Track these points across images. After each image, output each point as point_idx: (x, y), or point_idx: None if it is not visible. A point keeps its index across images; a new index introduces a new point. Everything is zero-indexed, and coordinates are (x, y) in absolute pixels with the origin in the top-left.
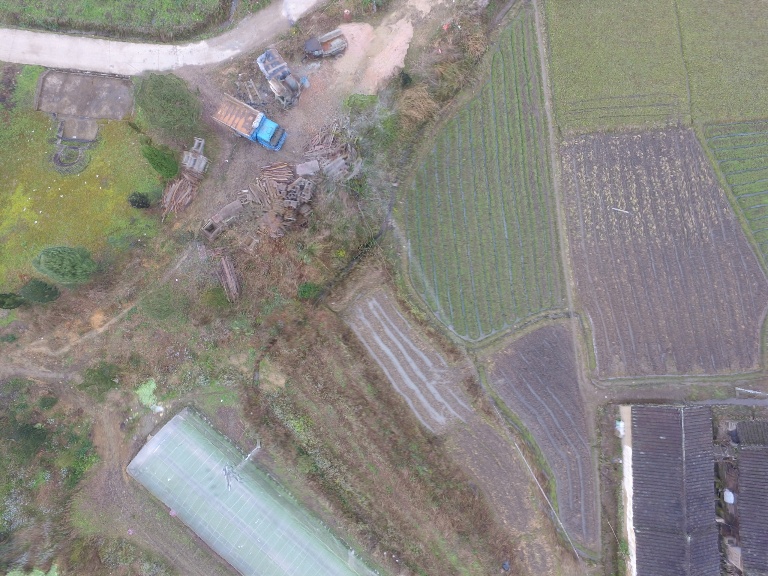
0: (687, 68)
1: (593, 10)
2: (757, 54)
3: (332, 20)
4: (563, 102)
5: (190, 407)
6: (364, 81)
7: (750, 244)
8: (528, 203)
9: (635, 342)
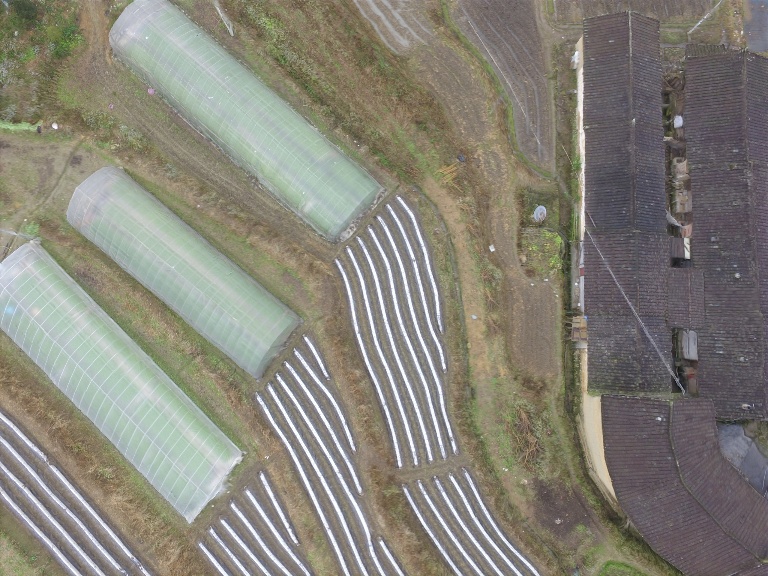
0: None
1: None
2: None
3: None
4: None
5: None
6: None
7: None
8: None
9: None
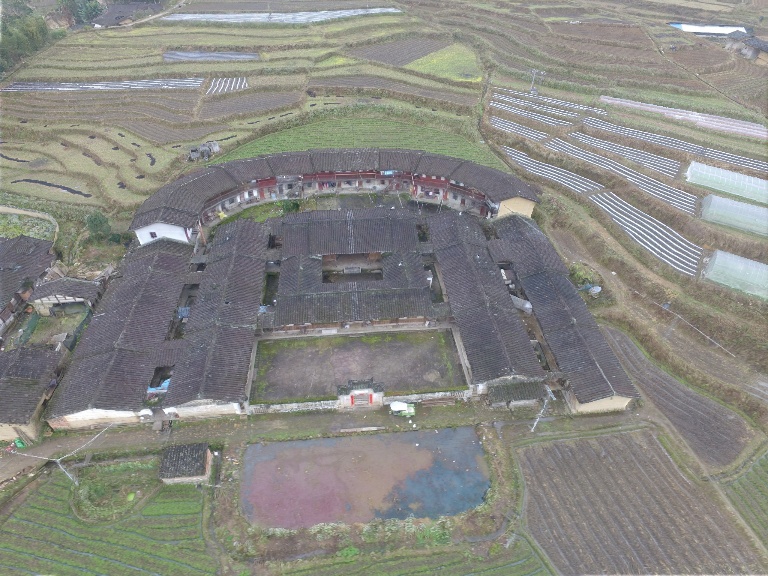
0: None
1: None
2: None
3: None
4: None
5: None
6: None
7: None
8: None
9: (635, 461)
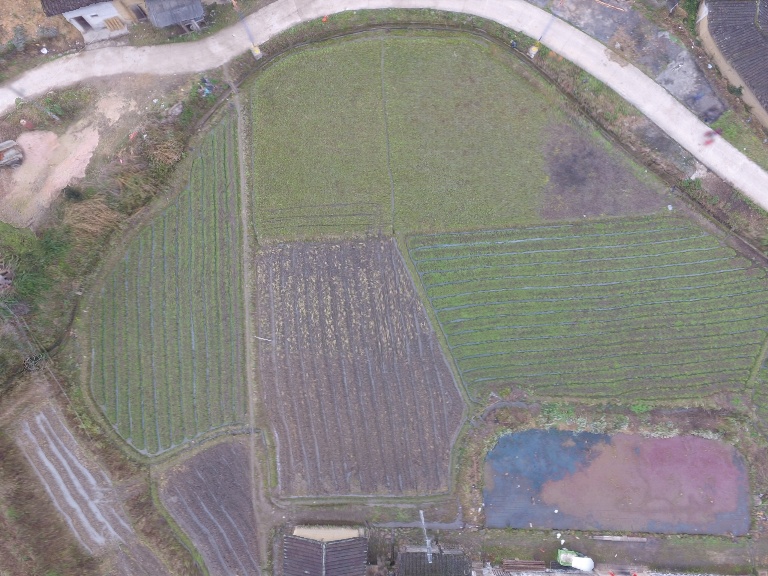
0: (393, 177)
1: (299, 116)
2: (466, 163)
3: (13, 128)
4: (261, 210)
5: None
6: (43, 190)
7: (447, 360)
8: (217, 314)
9: (320, 460)
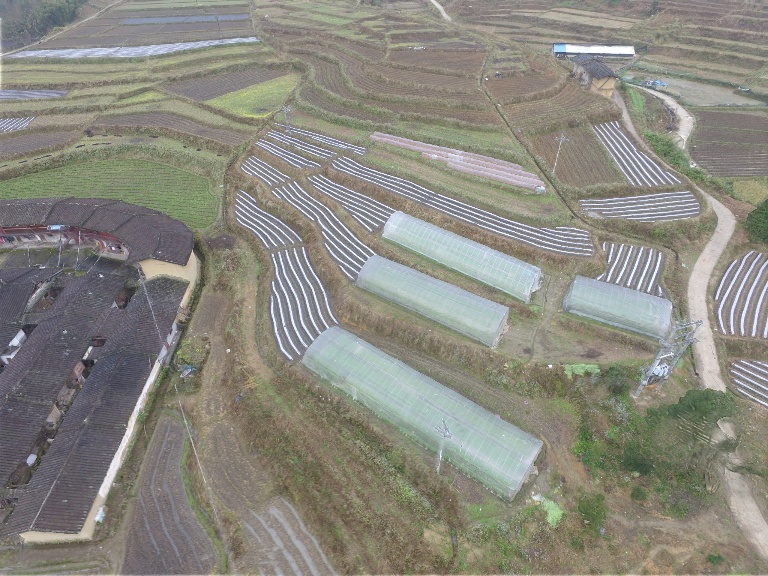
0: None
1: None
2: None
3: None
4: None
5: (509, 502)
6: None
7: None
8: None
9: None
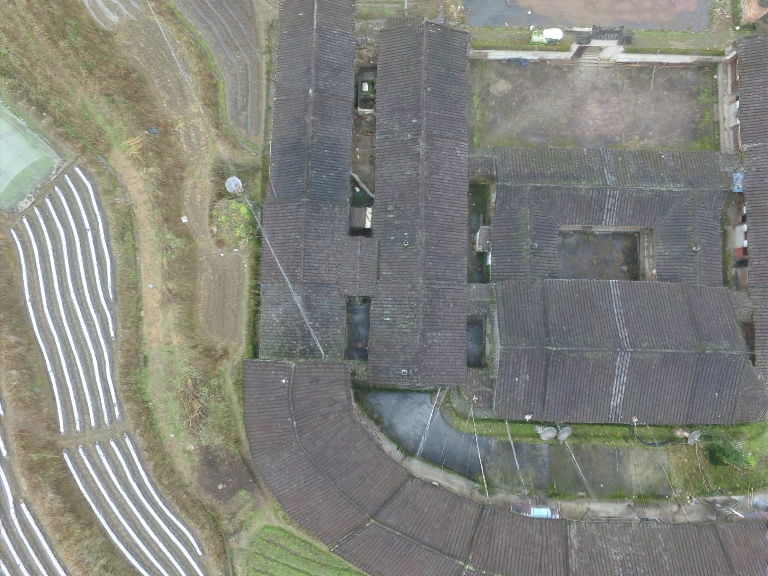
0: None
1: None
2: None
3: None
4: None
5: None
6: None
7: None
8: None
9: None
